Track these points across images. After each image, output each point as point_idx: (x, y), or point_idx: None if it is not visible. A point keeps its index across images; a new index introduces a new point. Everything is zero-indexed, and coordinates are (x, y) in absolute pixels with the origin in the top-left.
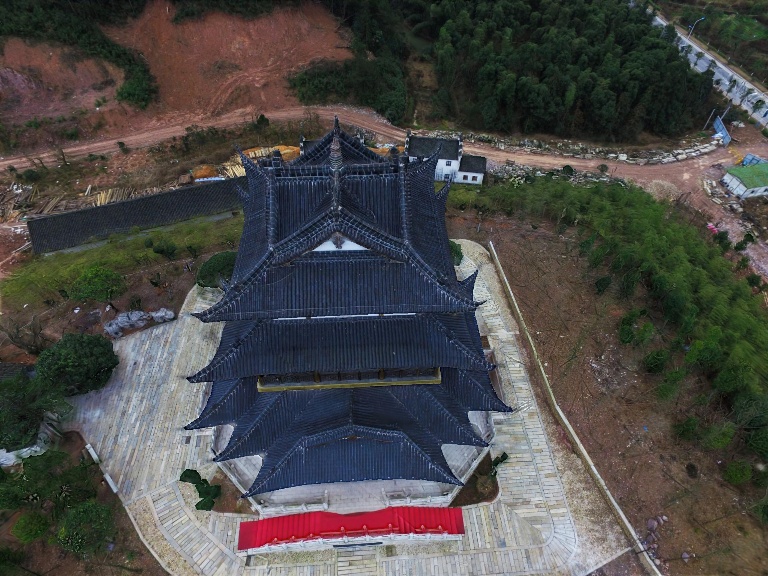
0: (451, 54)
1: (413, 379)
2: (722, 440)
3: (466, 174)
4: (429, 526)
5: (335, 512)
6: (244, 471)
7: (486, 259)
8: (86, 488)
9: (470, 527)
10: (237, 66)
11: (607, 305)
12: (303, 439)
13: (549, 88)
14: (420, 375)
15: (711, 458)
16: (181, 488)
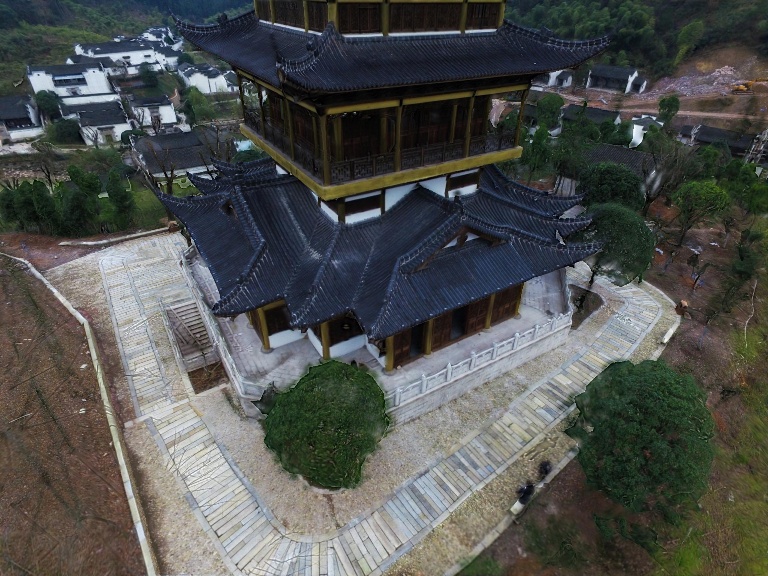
0: None
1: None
2: None
3: None
4: None
5: None
6: None
7: None
8: None
9: None
10: None
11: None
12: None
13: None
14: None
15: None
16: None
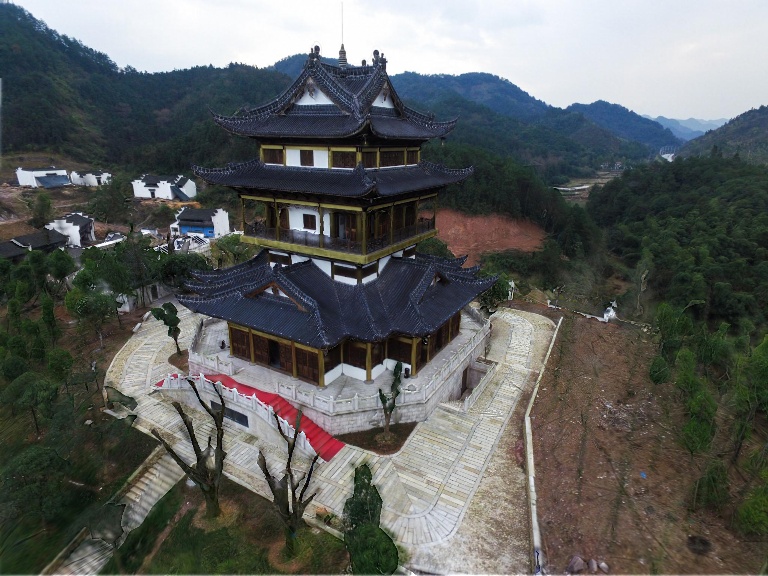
0: (647, 265)
1: (344, 252)
2: (766, 507)
3: None
4: None
5: (234, 379)
6: (207, 340)
7: (549, 327)
8: None
9: (338, 460)
10: (447, 242)
11: None
12: (245, 286)
13: (758, 300)
14: (352, 251)
15: (755, 555)
16: (166, 345)
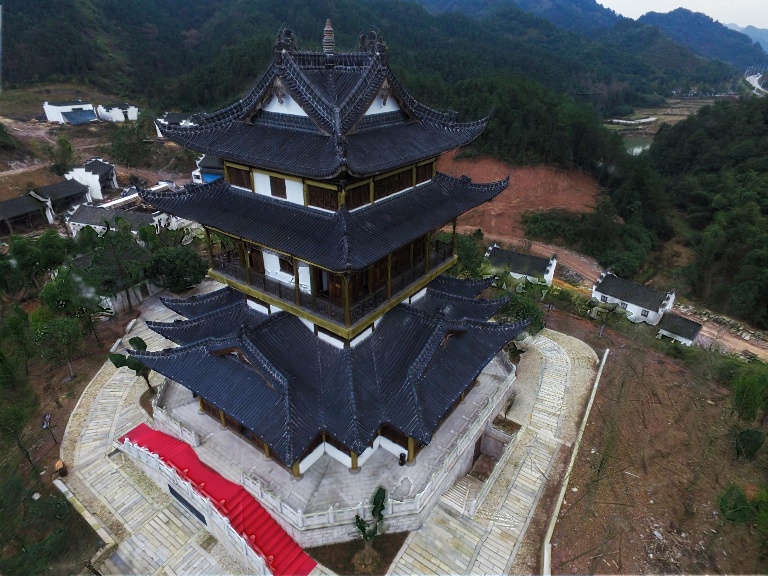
0: (716, 235)
1: (324, 318)
2: None
3: (666, 334)
4: (261, 544)
5: (197, 454)
6: None
7: (590, 364)
8: (91, 322)
9: None
10: None
11: (748, 482)
12: (210, 340)
13: None
14: (333, 317)
15: None
16: None
